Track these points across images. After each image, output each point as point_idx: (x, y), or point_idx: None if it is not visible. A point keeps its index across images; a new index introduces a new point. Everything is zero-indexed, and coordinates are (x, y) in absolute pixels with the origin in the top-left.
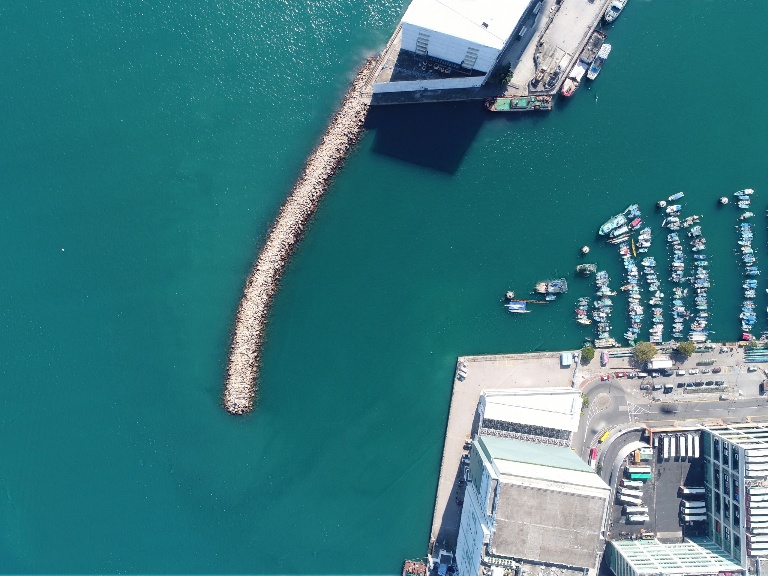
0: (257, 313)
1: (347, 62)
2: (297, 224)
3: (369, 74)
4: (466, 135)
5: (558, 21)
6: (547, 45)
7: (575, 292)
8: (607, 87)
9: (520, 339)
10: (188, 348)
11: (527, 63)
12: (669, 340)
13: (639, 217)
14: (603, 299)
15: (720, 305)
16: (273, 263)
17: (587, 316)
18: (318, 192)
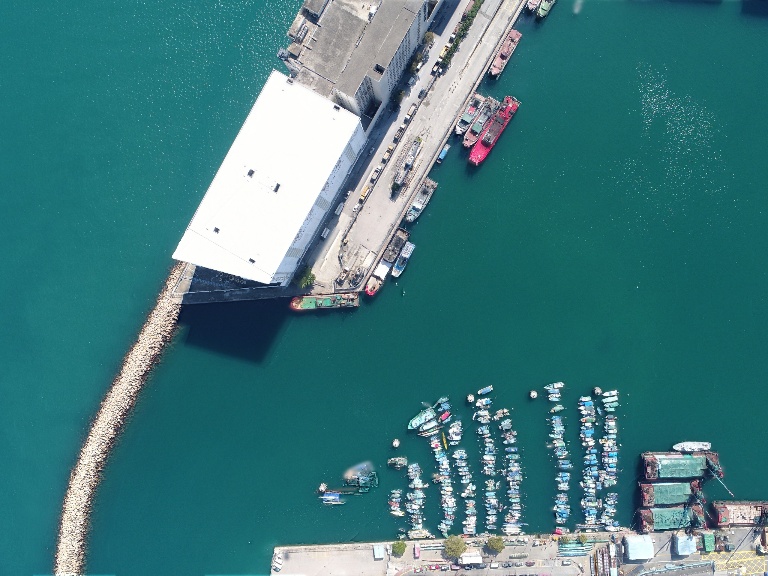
0: (80, 505)
1: (161, 261)
2: (116, 419)
3: (179, 275)
4: (277, 331)
5: (361, 220)
6: (351, 244)
7: (388, 484)
8: (414, 282)
9: (334, 530)
10: (19, 536)
11: (332, 261)
12: (483, 532)
13: (449, 411)
14: (415, 491)
15: (533, 497)
16: (94, 457)
17: (400, 508)
18: (135, 388)
